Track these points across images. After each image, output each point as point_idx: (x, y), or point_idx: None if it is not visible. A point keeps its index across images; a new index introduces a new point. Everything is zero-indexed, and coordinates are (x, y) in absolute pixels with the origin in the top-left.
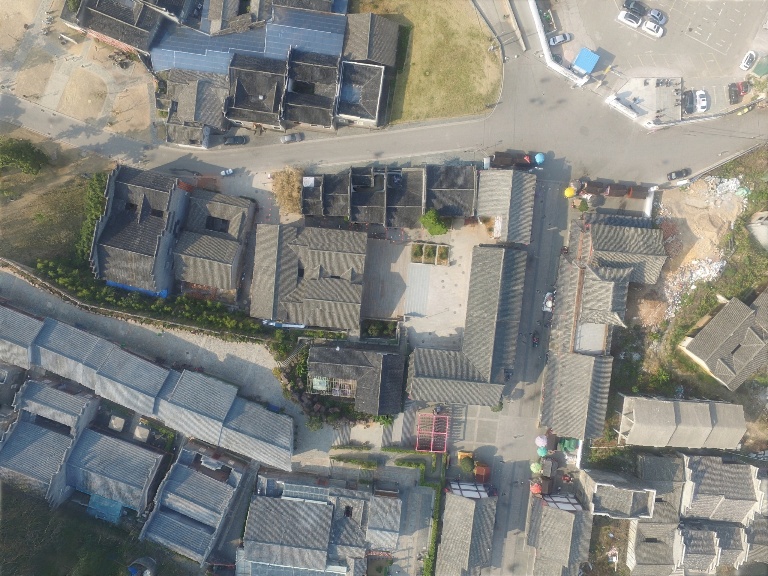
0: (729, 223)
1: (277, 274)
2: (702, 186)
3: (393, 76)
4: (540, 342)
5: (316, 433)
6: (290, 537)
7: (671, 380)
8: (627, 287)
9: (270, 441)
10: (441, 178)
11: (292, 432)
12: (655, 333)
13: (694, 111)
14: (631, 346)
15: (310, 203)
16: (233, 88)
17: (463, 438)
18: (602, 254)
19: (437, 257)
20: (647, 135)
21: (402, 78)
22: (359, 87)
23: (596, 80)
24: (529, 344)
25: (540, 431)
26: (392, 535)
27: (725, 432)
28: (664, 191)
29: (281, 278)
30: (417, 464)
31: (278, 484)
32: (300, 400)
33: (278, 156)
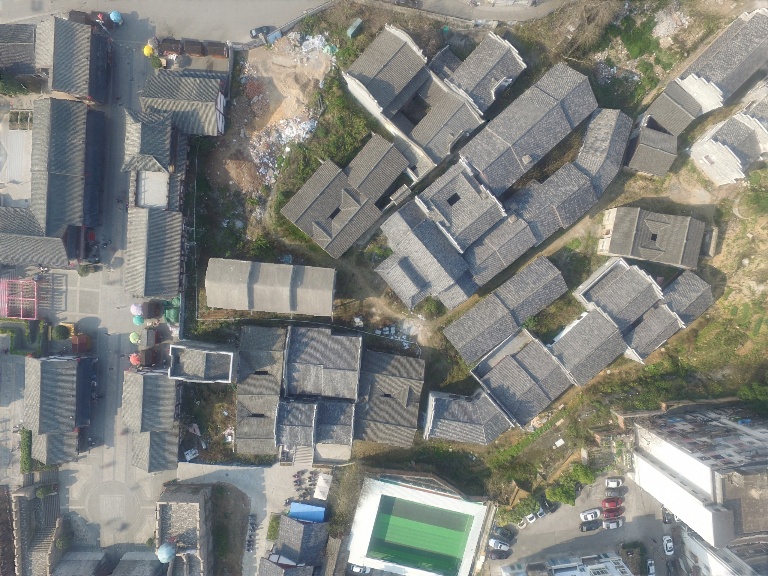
0: (316, 81)
1: None
2: (284, 43)
3: None
4: None
5: None
6: None
7: (273, 248)
8: (169, 132)
9: None
10: (7, 34)
11: None
12: (256, 199)
13: None
14: (233, 213)
15: None
16: None
17: (65, 309)
18: (151, 102)
19: (29, 122)
20: None
21: None
22: None
23: None
24: None
25: (142, 301)
26: None
27: (311, 295)
28: (249, 50)
29: None
30: (4, 330)
31: None
32: None
33: None
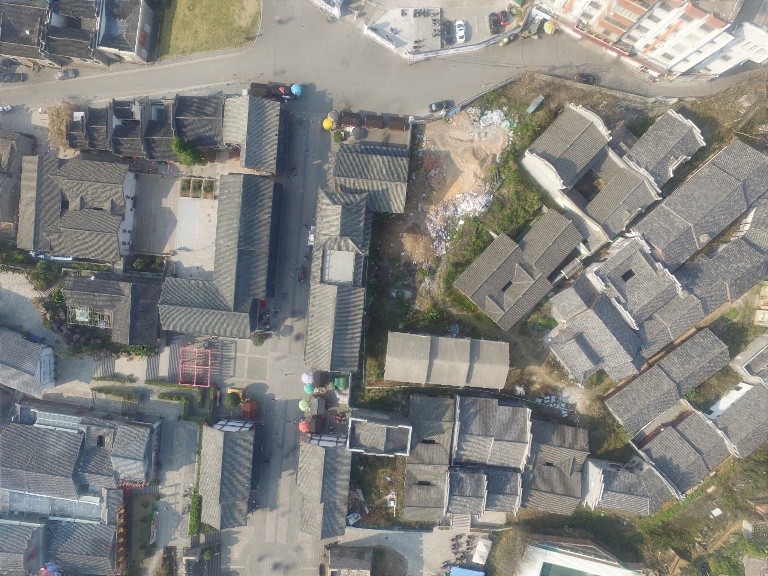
0: (493, 156)
1: (38, 204)
2: (463, 118)
3: (163, 12)
4: (308, 278)
5: (77, 364)
6: (36, 463)
7: (443, 318)
8: (363, 213)
9: (14, 366)
10: (192, 107)
11: (52, 362)
12: (426, 270)
13: (455, 42)
14: (402, 283)
15: (76, 136)
16: (1, 23)
17: (233, 375)
18: (342, 181)
19: (202, 191)
20: (408, 67)
21: (170, 13)
22: (123, 21)
23: (352, 10)
24: (297, 279)
25: None
26: (136, 464)
27: (488, 369)
28: (427, 123)
29: (43, 209)
30: (178, 397)
31: (34, 413)
32: (59, 330)
33: (55, 93)
